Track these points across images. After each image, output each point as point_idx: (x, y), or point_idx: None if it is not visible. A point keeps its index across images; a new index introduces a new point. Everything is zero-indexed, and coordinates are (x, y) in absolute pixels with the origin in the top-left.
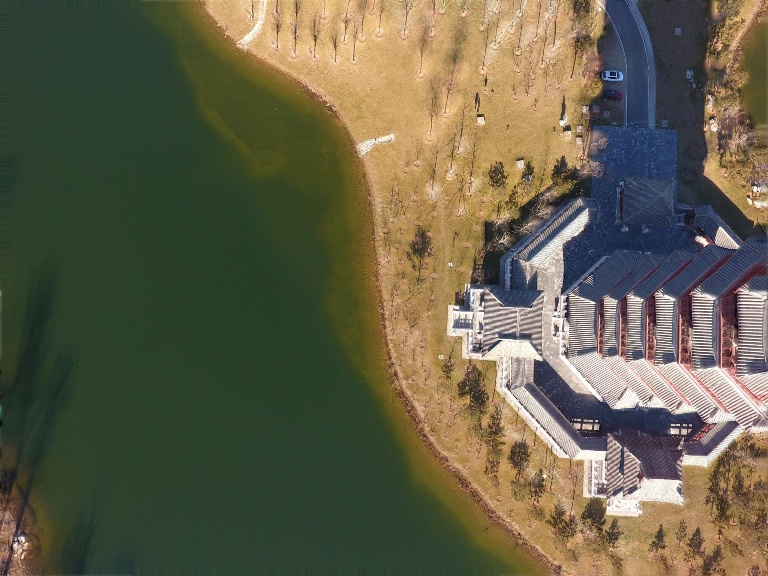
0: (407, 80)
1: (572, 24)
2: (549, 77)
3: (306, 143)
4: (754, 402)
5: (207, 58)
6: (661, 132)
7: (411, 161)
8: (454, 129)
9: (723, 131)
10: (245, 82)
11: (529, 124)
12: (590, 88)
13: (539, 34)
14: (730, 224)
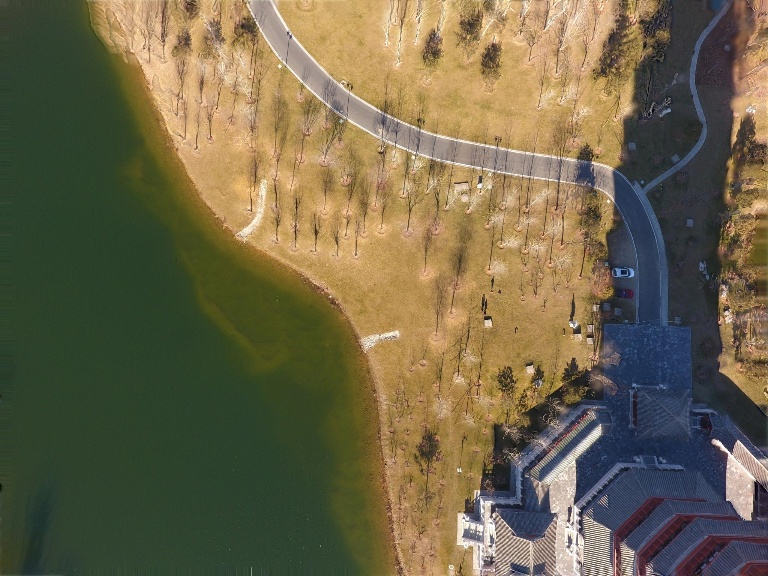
0: (411, 277)
1: (580, 219)
2: (558, 275)
3: (308, 336)
4: None
5: (205, 249)
6: (674, 329)
7: (417, 360)
8: (461, 330)
9: (738, 320)
10: (245, 273)
11: (538, 326)
12: (600, 293)
13: (546, 231)
14: (747, 421)
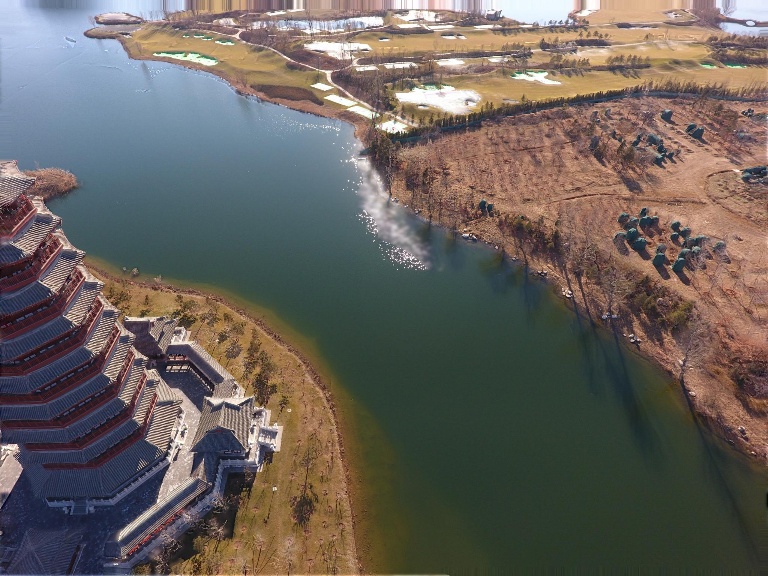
0: None
1: None
2: None
3: None
4: None
5: None
6: None
7: None
8: None
9: None
10: None
11: None
12: None
13: None
14: None
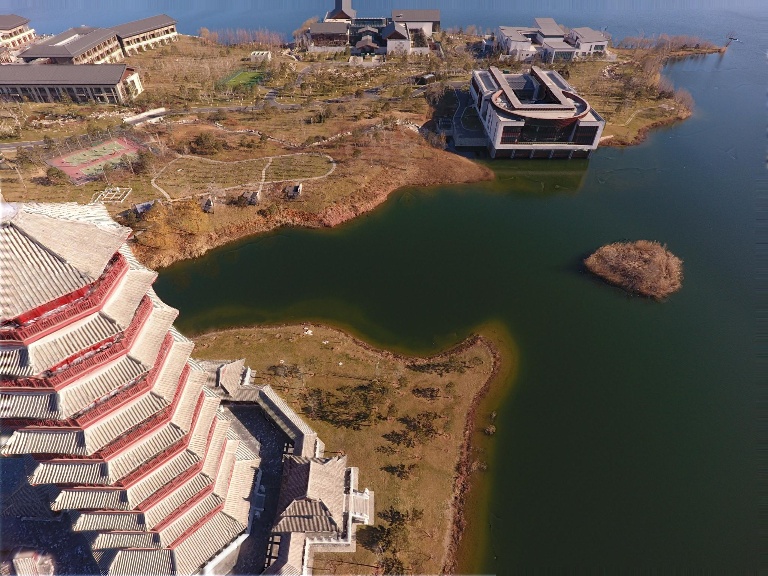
0: None
1: None
2: None
3: None
4: (146, 431)
5: None
6: None
7: None
8: None
9: None
10: None
11: None
12: None
13: None
14: None
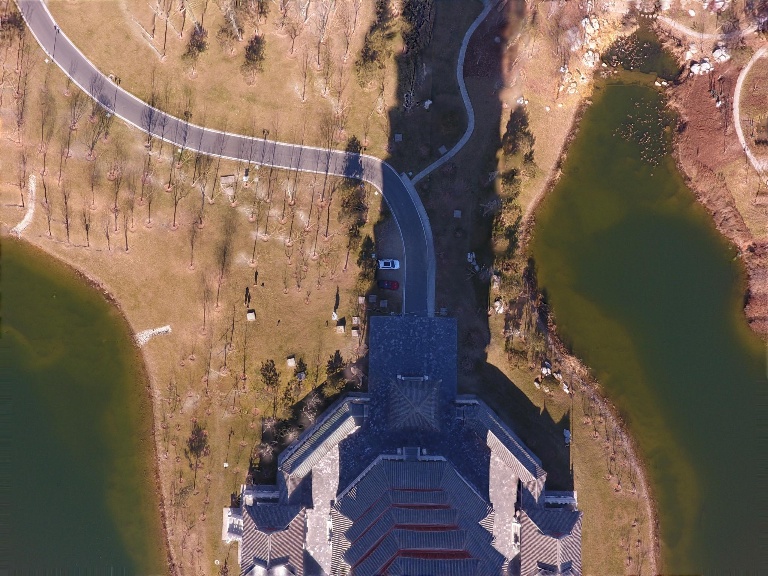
0: (179, 272)
1: None
2: (322, 268)
3: (86, 332)
4: None
5: None
6: (440, 320)
7: (187, 354)
8: (226, 324)
9: (511, 311)
10: (22, 269)
11: (301, 319)
12: (358, 284)
13: (311, 223)
14: (516, 412)
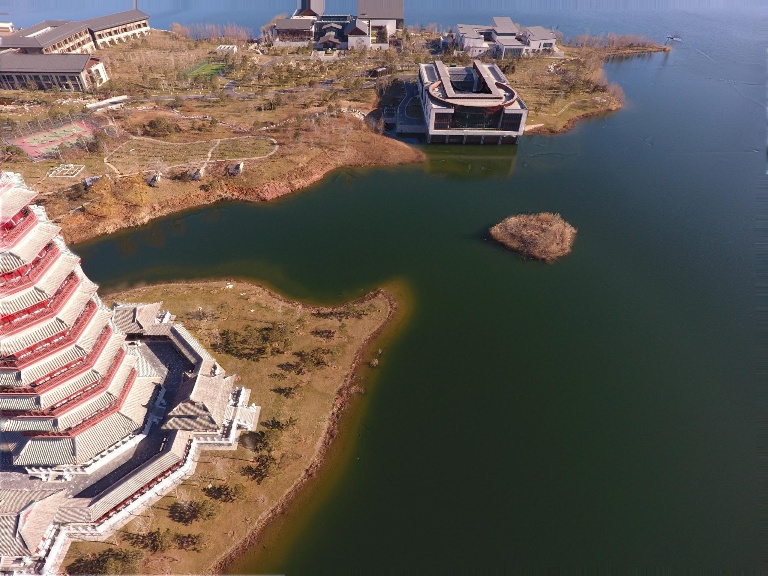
0: None
1: None
2: None
3: None
4: (34, 321)
5: None
6: None
7: None
8: None
9: None
10: None
11: None
12: None
13: None
14: None
